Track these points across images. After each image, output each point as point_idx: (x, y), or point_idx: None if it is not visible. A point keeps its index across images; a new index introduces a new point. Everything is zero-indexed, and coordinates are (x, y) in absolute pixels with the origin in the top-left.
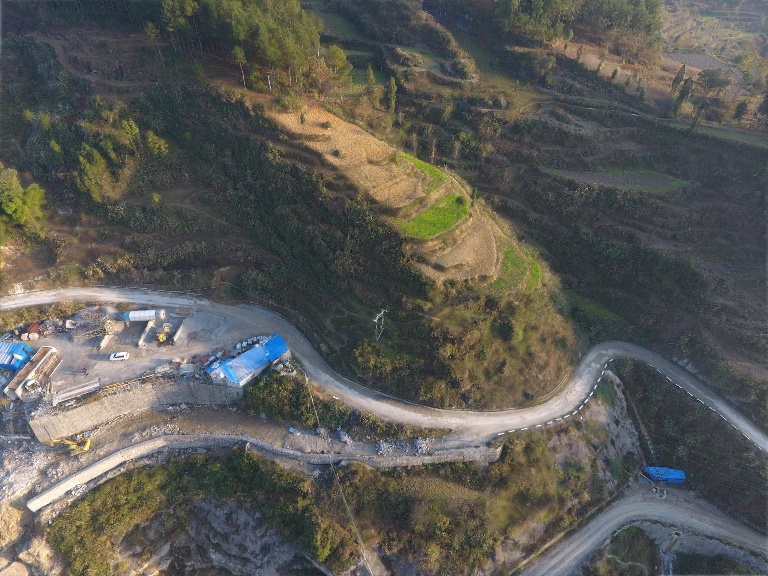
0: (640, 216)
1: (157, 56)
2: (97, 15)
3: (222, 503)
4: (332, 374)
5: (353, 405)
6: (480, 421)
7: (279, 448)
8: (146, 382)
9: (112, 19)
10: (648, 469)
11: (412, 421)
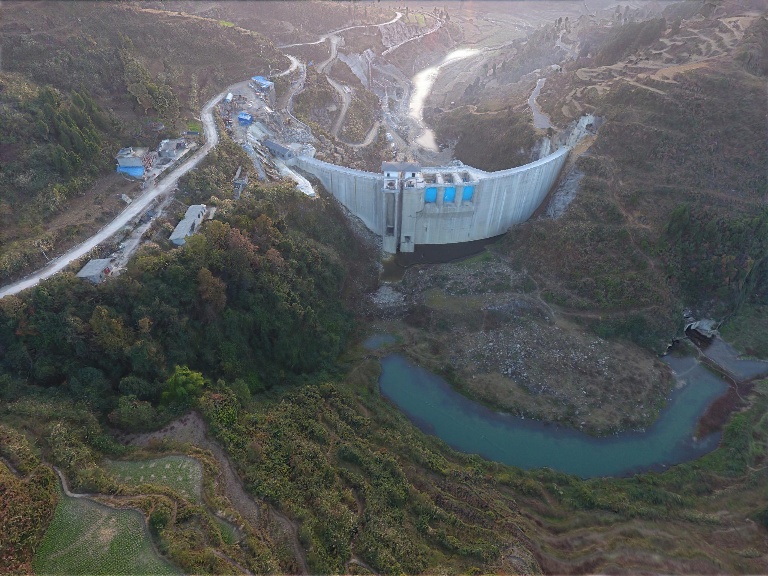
0: (225, 15)
1: (61, 3)
2: None
3: (310, 113)
4: (272, 76)
5: (286, 74)
6: (295, 64)
7: (298, 89)
8: (267, 99)
9: None
10: (309, 65)
11: (294, 69)
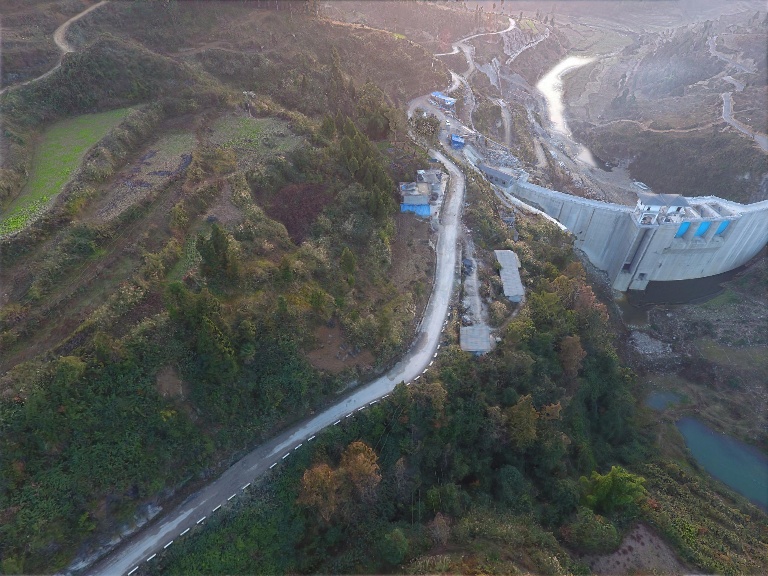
0: None
1: (280, 18)
2: (227, 8)
3: None
4: None
5: None
6: (454, 77)
7: (473, 105)
8: None
9: (232, 8)
10: None
11: None
